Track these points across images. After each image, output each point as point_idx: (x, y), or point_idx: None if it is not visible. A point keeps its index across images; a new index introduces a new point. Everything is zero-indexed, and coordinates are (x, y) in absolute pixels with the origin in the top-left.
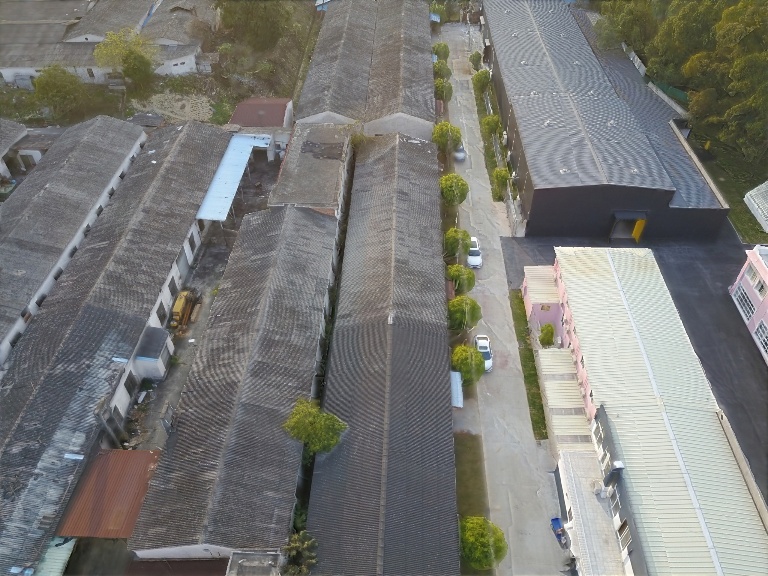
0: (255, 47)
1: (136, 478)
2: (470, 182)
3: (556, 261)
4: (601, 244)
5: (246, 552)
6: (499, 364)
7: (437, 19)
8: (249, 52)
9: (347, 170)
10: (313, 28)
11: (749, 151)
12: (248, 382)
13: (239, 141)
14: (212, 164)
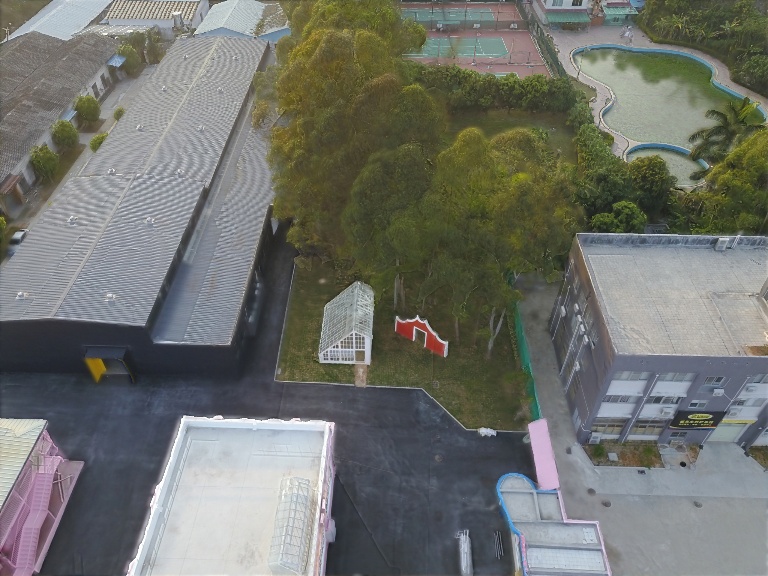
0: None
1: None
2: None
3: None
4: (88, 384)
5: None
6: None
7: (118, 63)
8: None
9: None
10: None
11: (297, 261)
12: None
13: None
14: None
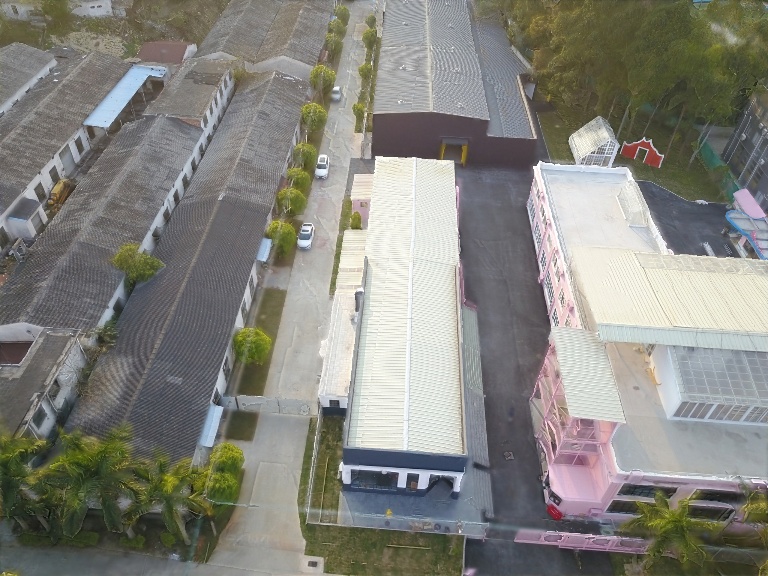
0: None
1: None
2: (339, 117)
3: None
4: None
5: (54, 328)
6: (318, 245)
7: None
8: (164, 3)
9: (228, 99)
10: None
11: (565, 96)
12: (89, 229)
13: (137, 71)
14: (107, 86)
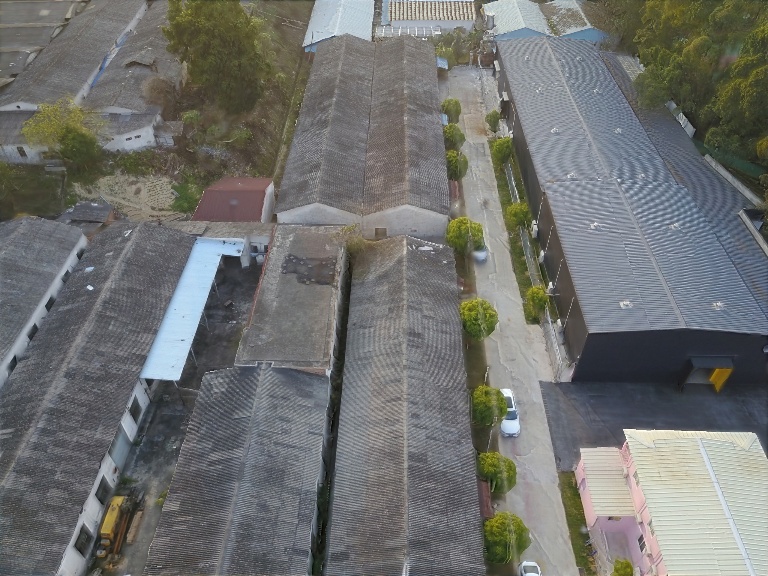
0: (228, 110)
1: None
2: (495, 294)
3: (625, 446)
4: (671, 394)
5: None
6: None
7: (444, 65)
8: (221, 116)
9: (341, 288)
10: (300, 74)
11: None
12: None
13: (204, 248)
14: (167, 287)
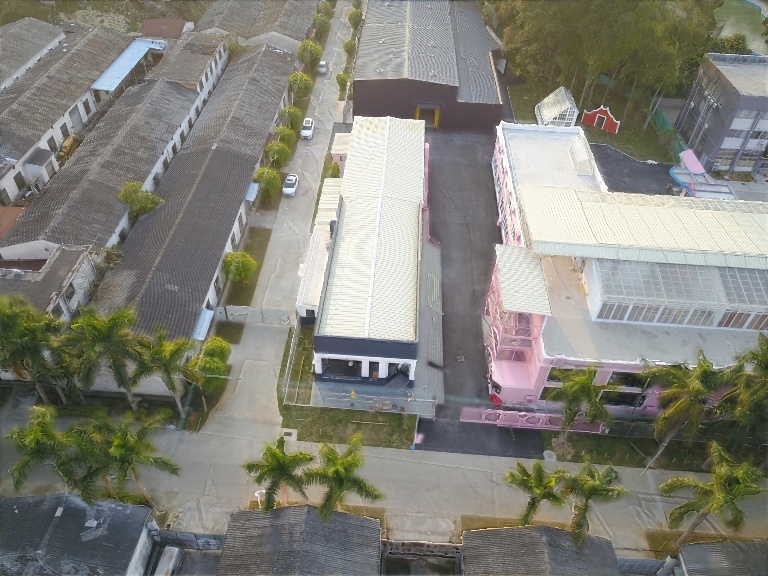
0: None
1: (9, 219)
2: (325, 88)
3: None
4: None
5: (69, 244)
6: (301, 193)
7: None
8: None
9: (222, 69)
10: None
11: (530, 68)
12: (97, 170)
13: (139, 44)
14: (112, 55)
